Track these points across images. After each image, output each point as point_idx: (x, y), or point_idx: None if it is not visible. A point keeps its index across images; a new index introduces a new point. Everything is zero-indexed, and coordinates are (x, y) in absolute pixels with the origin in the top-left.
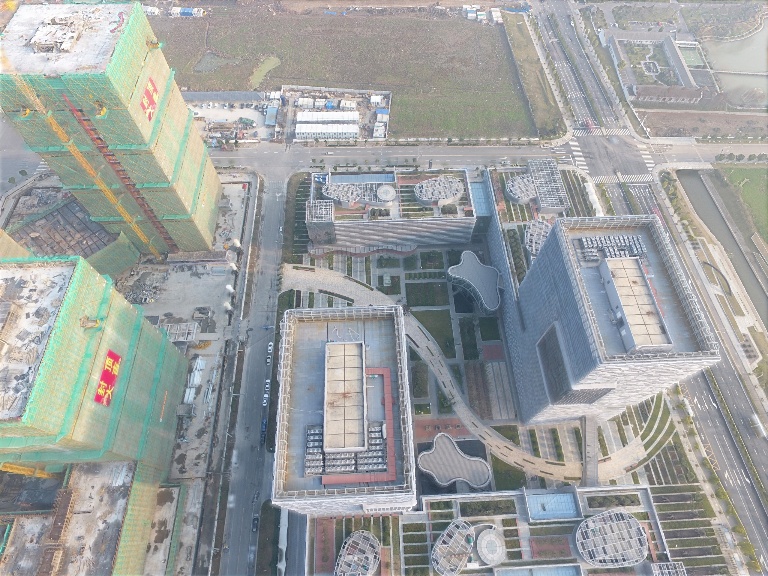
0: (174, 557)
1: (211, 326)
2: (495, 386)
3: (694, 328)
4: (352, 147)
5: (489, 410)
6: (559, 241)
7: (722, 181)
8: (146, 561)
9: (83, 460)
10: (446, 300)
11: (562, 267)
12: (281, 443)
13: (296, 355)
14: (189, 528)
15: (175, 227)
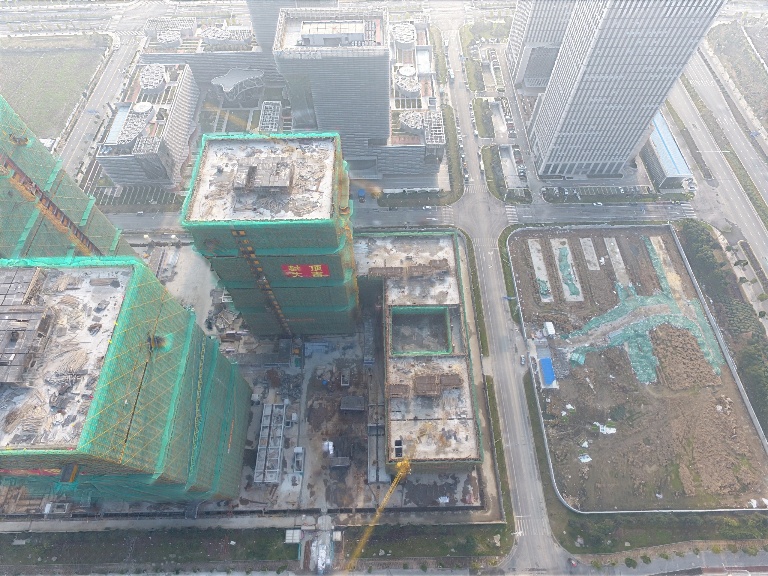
0: None
1: None
2: None
3: None
4: None
5: None
6: None
7: None
8: None
9: None
10: (245, 111)
11: None
12: None
13: None
14: None
15: None
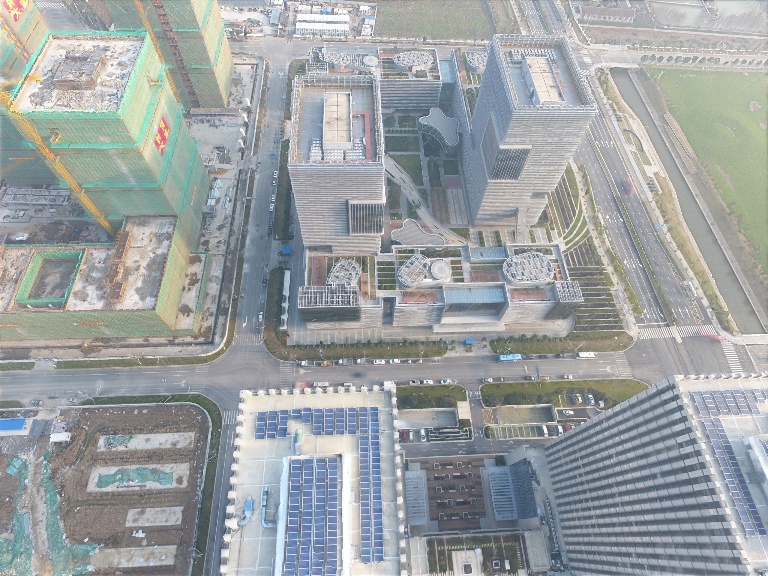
0: (203, 298)
1: (227, 160)
2: (453, 204)
3: (583, 98)
4: (343, 43)
5: (448, 218)
6: (494, 50)
7: (645, 76)
8: (182, 296)
9: (138, 209)
10: (417, 148)
11: (495, 67)
12: (294, 139)
13: (303, 105)
14: (213, 284)
15: (199, 80)
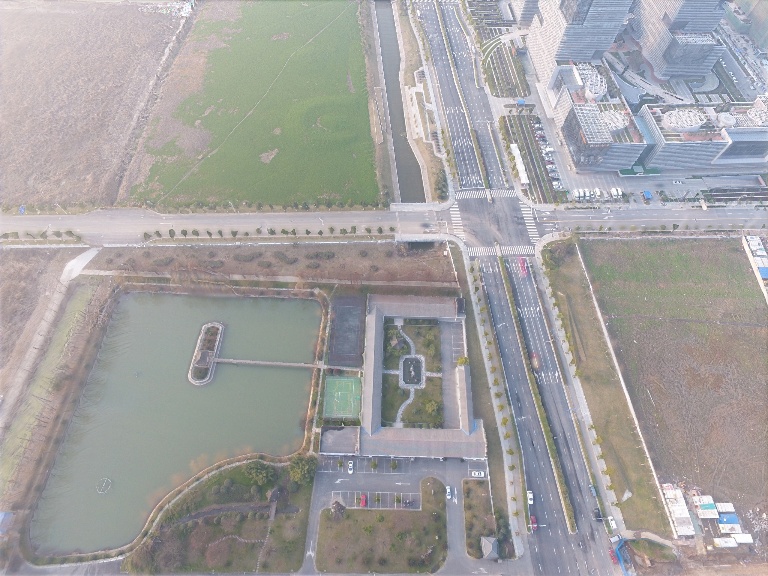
0: None
1: None
2: None
3: None
4: None
5: None
6: None
7: None
8: None
9: None
10: None
11: None
12: None
13: None
14: (723, 22)
15: None
